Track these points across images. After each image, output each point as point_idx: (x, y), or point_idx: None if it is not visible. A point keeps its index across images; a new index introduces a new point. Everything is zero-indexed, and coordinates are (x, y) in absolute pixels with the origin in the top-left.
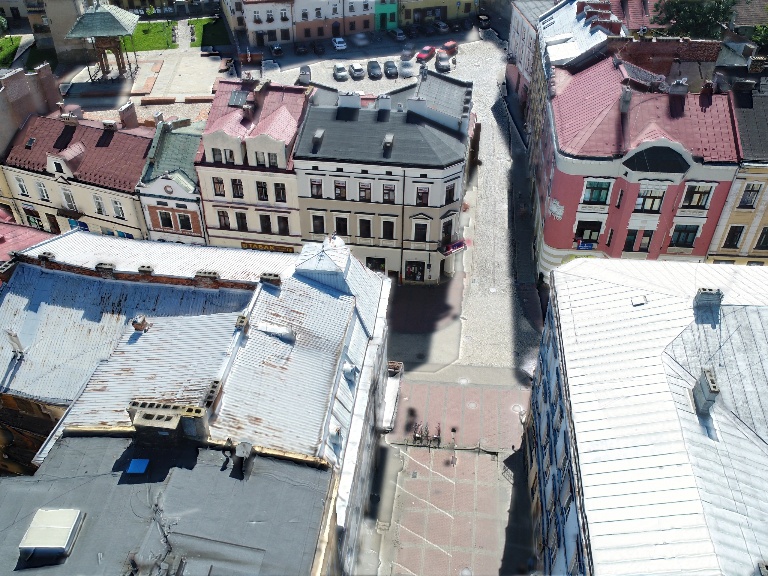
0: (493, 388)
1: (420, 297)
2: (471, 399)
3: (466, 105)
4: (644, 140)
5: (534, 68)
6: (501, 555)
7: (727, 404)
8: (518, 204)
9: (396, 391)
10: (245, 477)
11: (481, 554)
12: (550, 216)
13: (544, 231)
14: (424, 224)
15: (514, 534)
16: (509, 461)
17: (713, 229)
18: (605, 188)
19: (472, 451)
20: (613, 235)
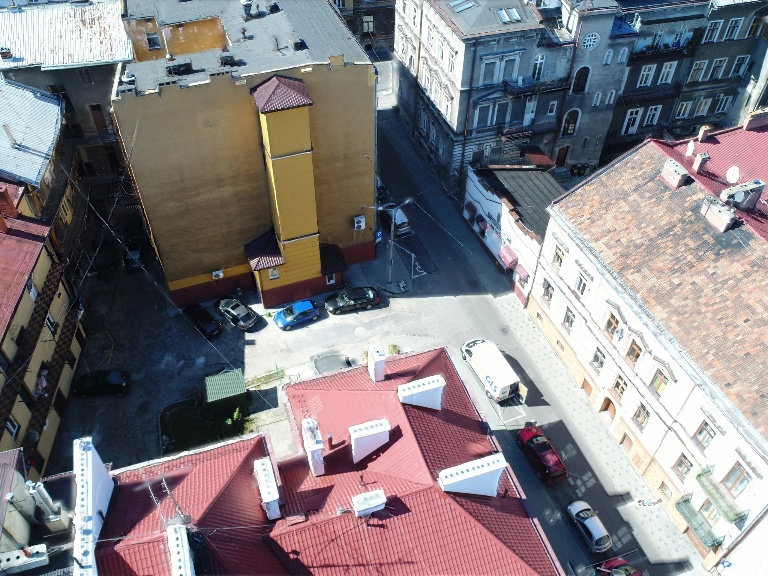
0: None
1: None
2: None
3: None
4: None
5: None
6: None
7: None
8: None
9: None
10: None
11: None
12: None
13: None
14: None
15: None
16: None
17: None
18: None
19: None
20: None
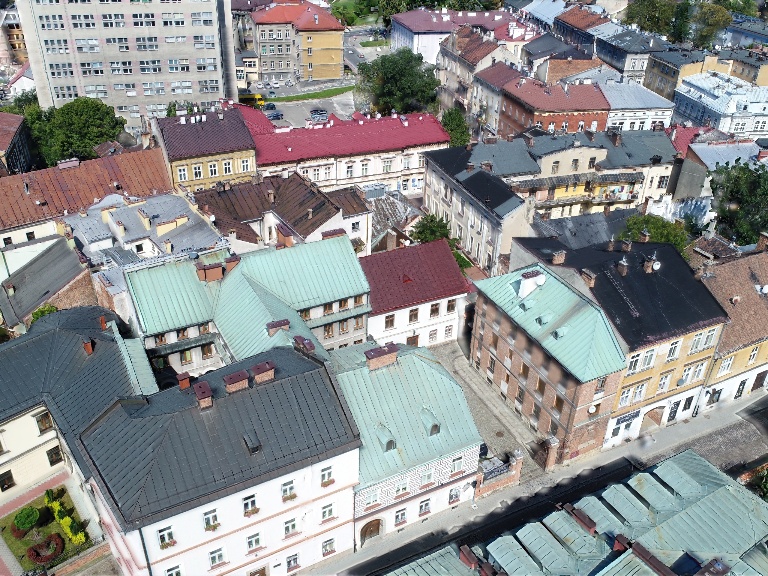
0: None
1: None
2: None
3: None
4: None
5: None
6: None
7: None
8: None
9: None
10: None
11: None
12: None
13: None
14: None
15: None
16: None
17: None
18: None
19: None
20: None
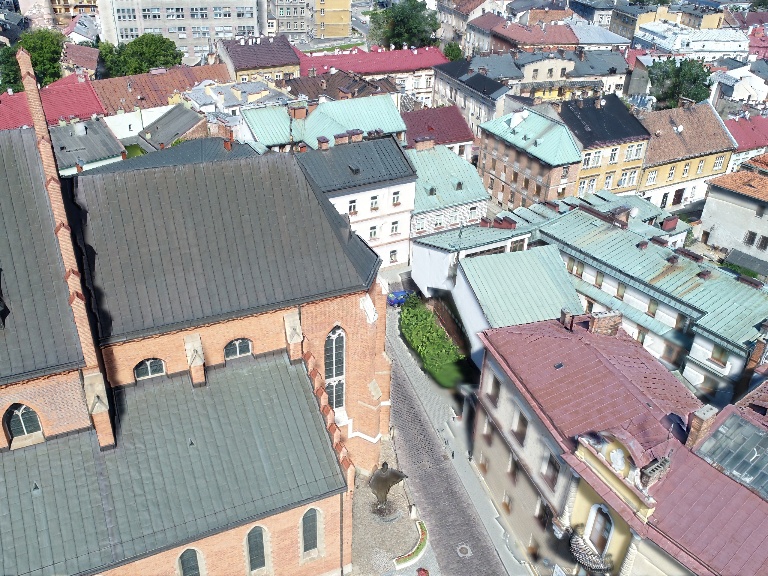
0: None
1: None
2: None
3: None
4: None
5: None
6: None
7: None
8: None
9: None
10: None
11: None
12: None
13: None
14: None
15: None
16: None
17: None
18: None
19: None
20: None
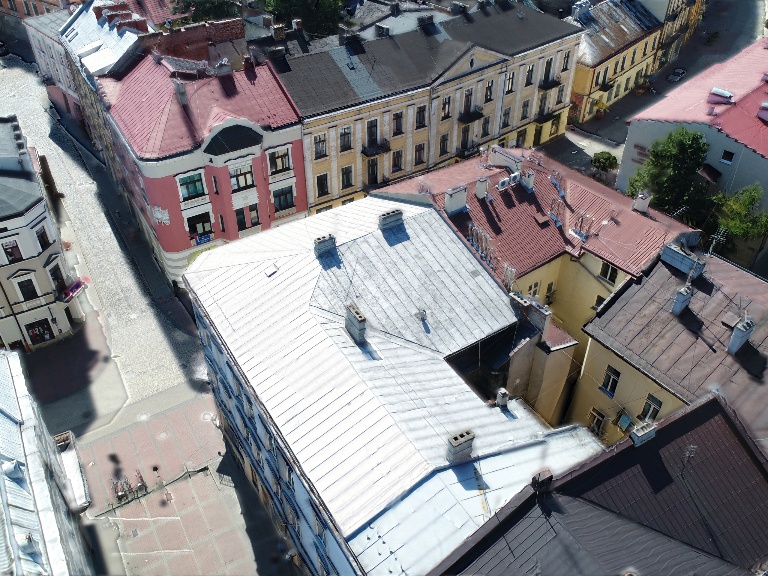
0: (176, 409)
1: (58, 356)
2: (159, 430)
3: (19, 141)
4: (214, 125)
5: (77, 84)
6: (252, 556)
7: (375, 326)
8: (121, 223)
9: (76, 463)
10: None
11: (234, 567)
12: (158, 224)
13: (158, 240)
14: (28, 280)
15: (255, 531)
16: (221, 468)
17: (304, 184)
18: (198, 180)
19: (182, 478)
20: (224, 220)
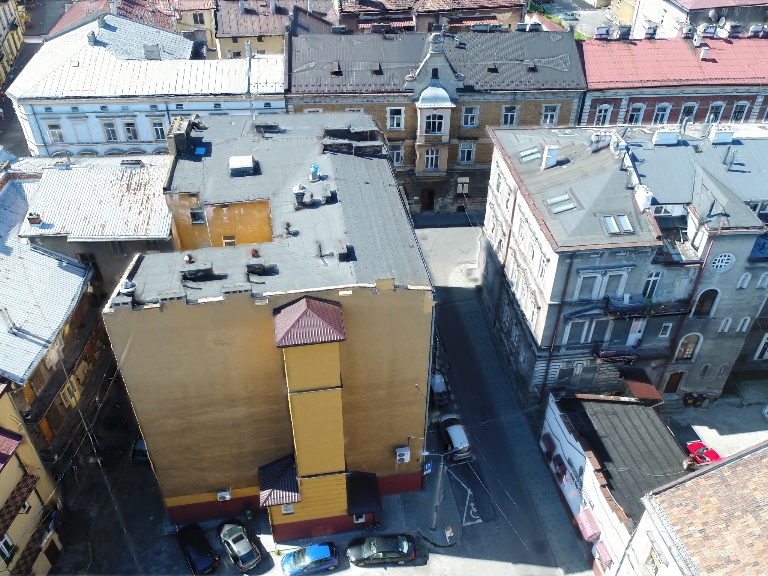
0: None
1: None
2: None
3: None
4: None
5: None
6: None
7: None
8: None
9: None
10: (207, 127)
11: None
12: None
13: None
14: None
15: None
16: None
17: None
18: None
19: None
20: None
